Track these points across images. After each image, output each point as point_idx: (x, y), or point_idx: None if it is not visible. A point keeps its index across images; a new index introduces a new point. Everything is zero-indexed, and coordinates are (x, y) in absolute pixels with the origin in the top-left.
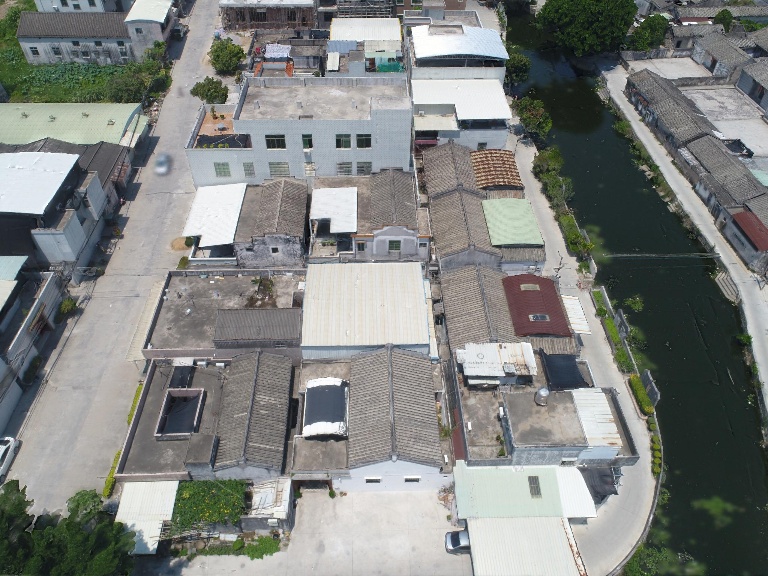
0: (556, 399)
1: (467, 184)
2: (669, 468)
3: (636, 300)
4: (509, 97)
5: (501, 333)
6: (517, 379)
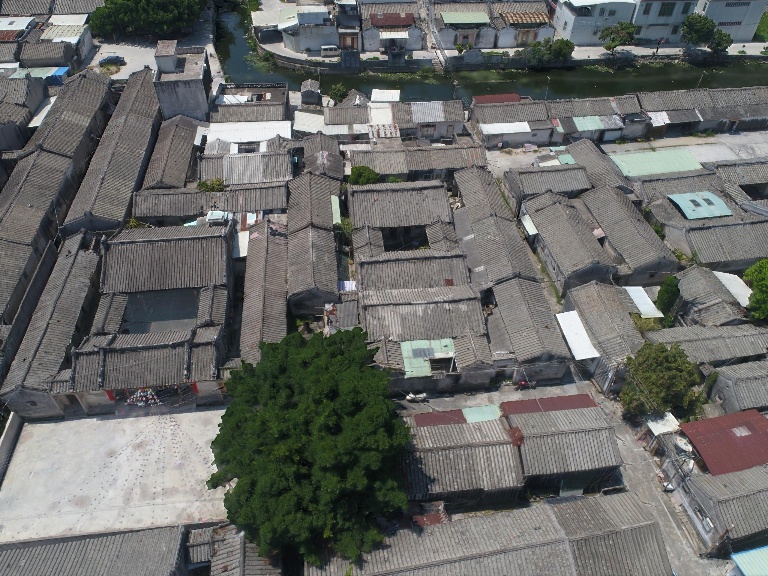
0: (320, 1)
1: (499, 7)
2: (314, 76)
3: (434, 82)
4: (681, 53)
5: (369, 8)
6: (340, 9)
